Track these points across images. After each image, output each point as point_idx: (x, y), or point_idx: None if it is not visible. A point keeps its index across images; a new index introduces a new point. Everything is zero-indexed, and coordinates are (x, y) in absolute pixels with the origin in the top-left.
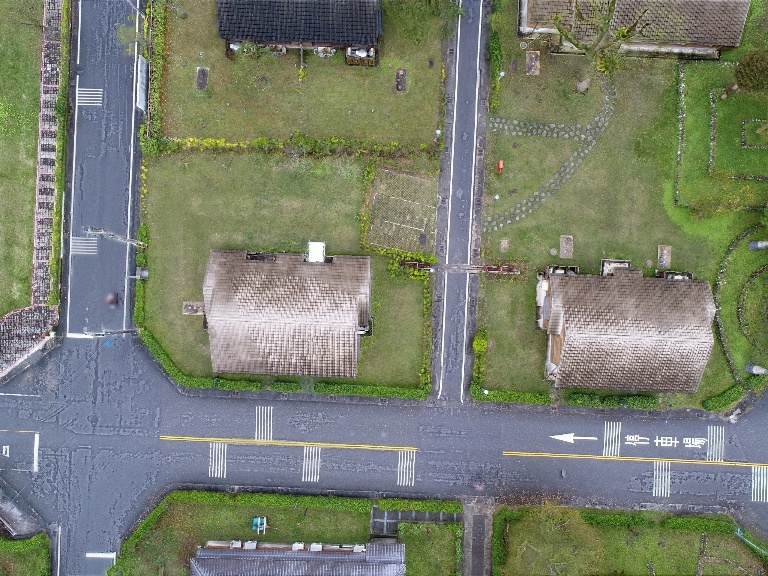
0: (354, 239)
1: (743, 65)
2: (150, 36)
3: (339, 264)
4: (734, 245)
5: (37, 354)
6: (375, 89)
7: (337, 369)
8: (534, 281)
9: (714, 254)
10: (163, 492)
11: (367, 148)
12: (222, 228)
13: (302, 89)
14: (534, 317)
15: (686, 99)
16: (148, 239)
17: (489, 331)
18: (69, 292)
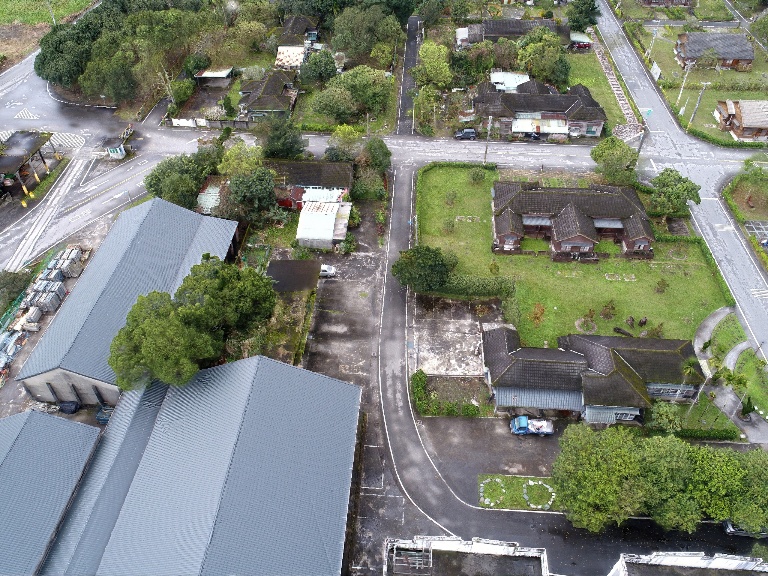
0: None
1: None
2: None
3: None
4: None
5: (637, 137)
6: None
7: None
8: None
9: None
10: (731, 178)
11: (765, 86)
12: None
13: None
14: None
15: None
16: None
17: None
18: None
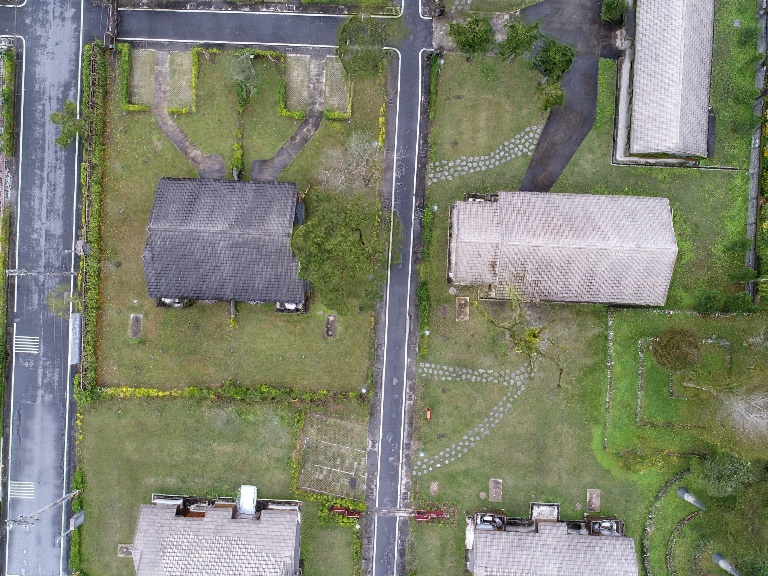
0: (285, 482)
1: (661, 346)
2: (83, 290)
3: (266, 521)
4: (662, 492)
5: None
6: (306, 335)
7: None
8: (463, 524)
9: (643, 498)
10: None
11: (297, 397)
12: (156, 472)
13: (234, 336)
14: (463, 560)
15: (615, 347)
16: (84, 483)
17: (418, 573)
18: (8, 534)
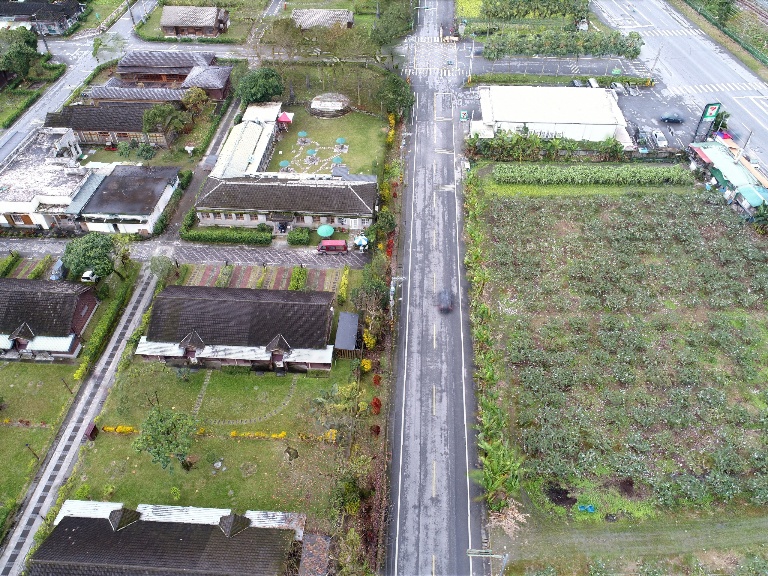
0: None
1: None
2: None
3: None
4: None
5: None
6: None
7: (207, 23)
8: None
9: None
10: None
11: (238, 3)
12: None
13: None
14: None
15: None
16: None
17: None
18: None
